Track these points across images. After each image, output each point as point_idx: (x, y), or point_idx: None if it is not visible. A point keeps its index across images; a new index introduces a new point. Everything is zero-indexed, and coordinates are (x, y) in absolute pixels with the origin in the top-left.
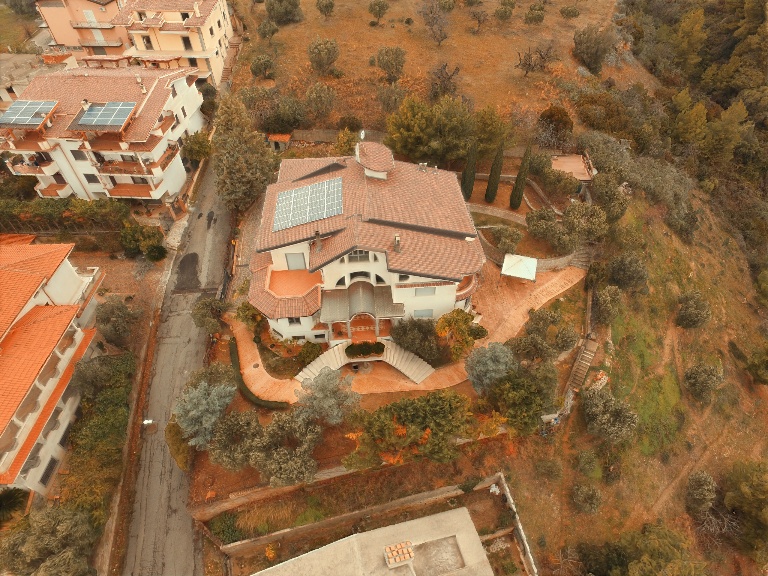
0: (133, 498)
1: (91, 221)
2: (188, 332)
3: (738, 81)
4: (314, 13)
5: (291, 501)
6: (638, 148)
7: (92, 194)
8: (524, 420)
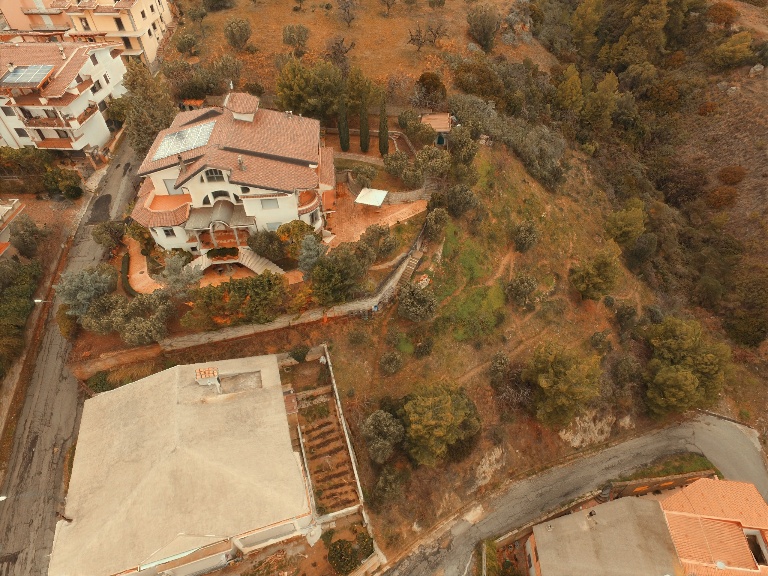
0: (33, 369)
1: (18, 166)
2: (94, 253)
3: (626, 58)
4: (246, 1)
5: (152, 363)
6: (510, 110)
7: (24, 147)
8: (325, 291)
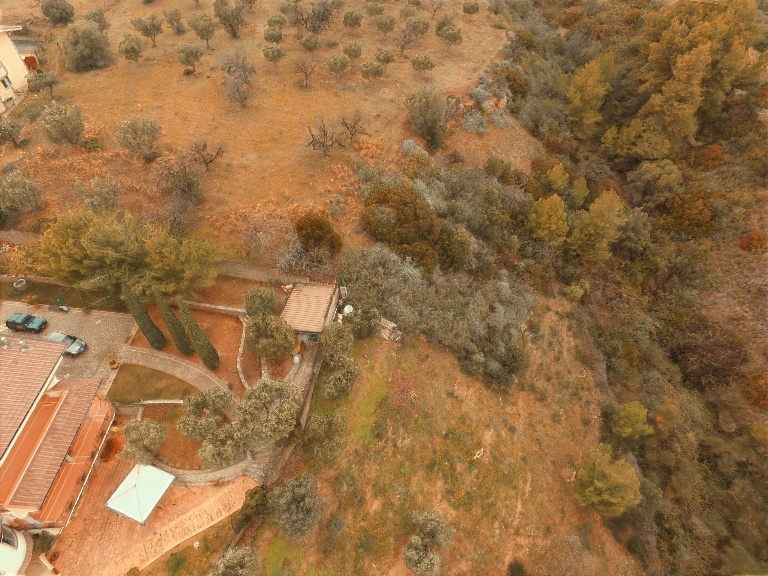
0: None
1: None
2: None
3: (639, 150)
4: None
5: None
6: (446, 261)
7: None
8: None
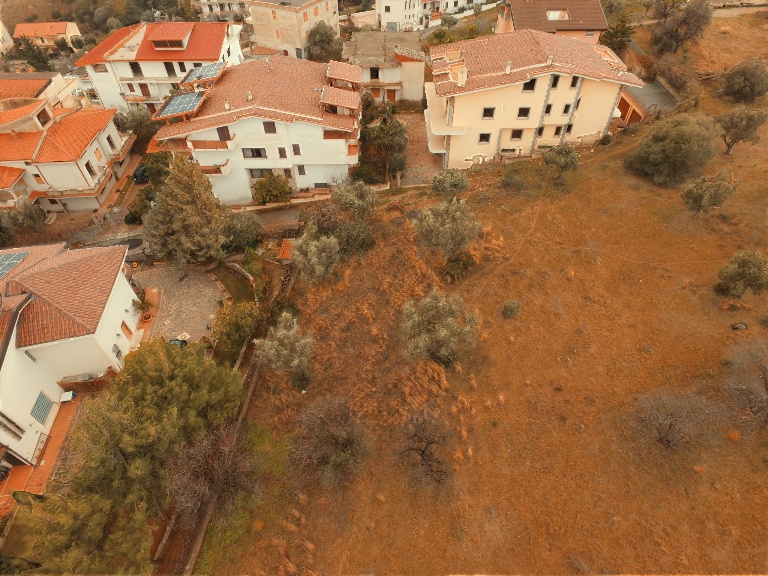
0: None
1: None
2: None
3: None
4: None
5: None
6: None
7: None
8: None
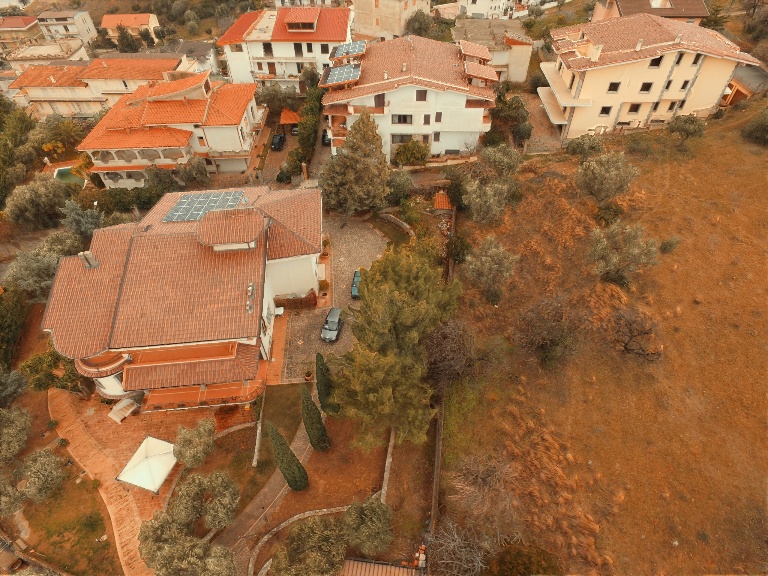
0: None
1: None
2: None
3: None
4: None
5: None
6: None
7: None
8: None
